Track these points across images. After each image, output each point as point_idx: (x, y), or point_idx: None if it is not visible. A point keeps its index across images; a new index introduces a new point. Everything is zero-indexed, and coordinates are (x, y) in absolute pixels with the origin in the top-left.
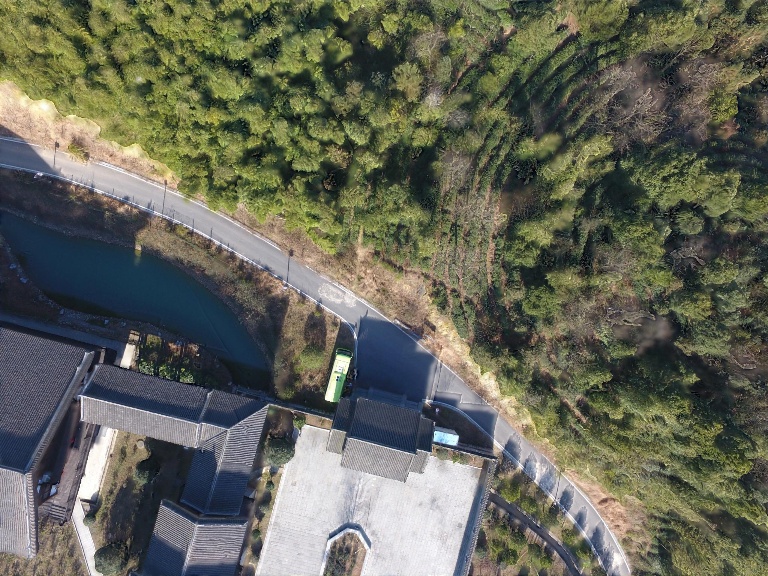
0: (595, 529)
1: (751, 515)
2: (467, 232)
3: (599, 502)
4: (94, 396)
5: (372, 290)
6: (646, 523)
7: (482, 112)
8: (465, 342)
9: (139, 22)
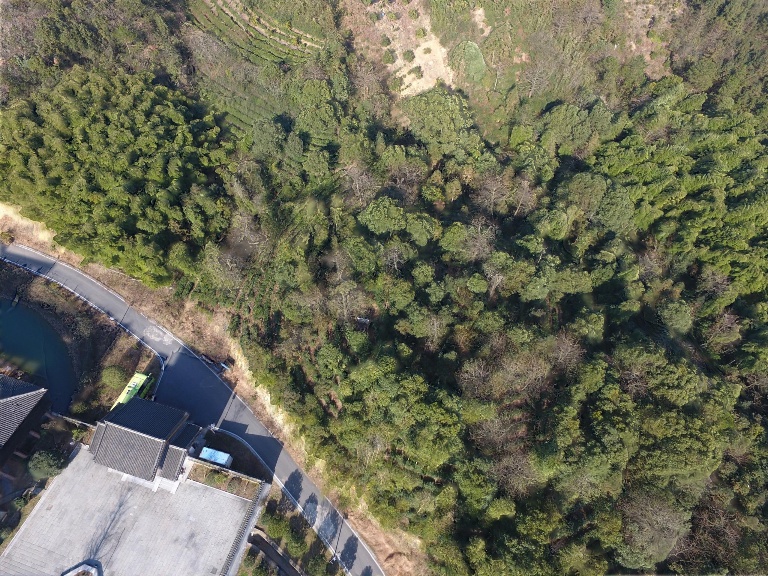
0: None
1: (479, 489)
2: None
3: (385, 559)
4: None
5: (188, 331)
6: (430, 575)
7: (280, 205)
8: None
9: (71, 153)
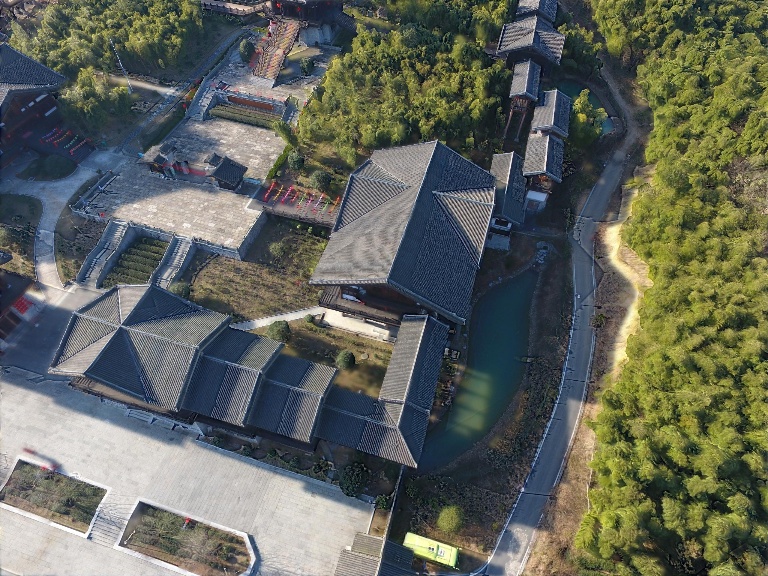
0: None
1: None
2: None
3: None
4: (427, 324)
5: None
6: None
7: None
8: None
9: (744, 364)
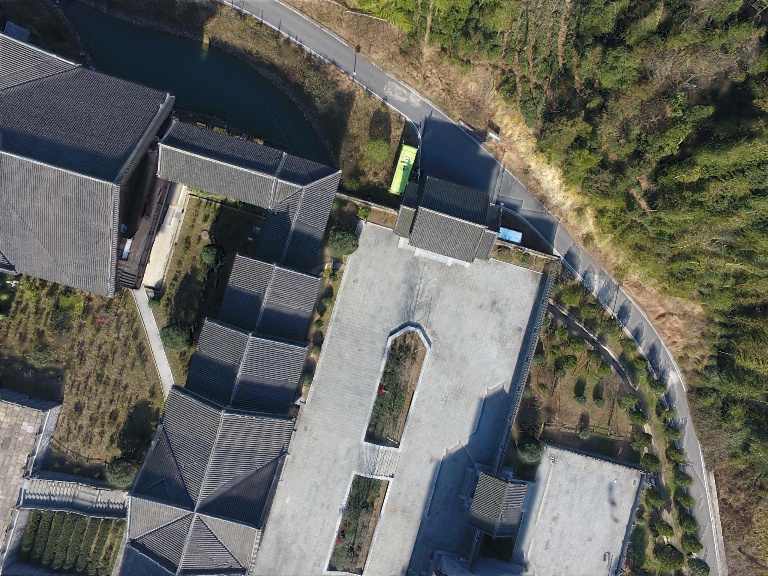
0: (652, 345)
1: None
2: (538, 18)
3: (656, 317)
4: (173, 146)
5: (437, 89)
6: (705, 332)
7: None
8: (532, 134)
9: None
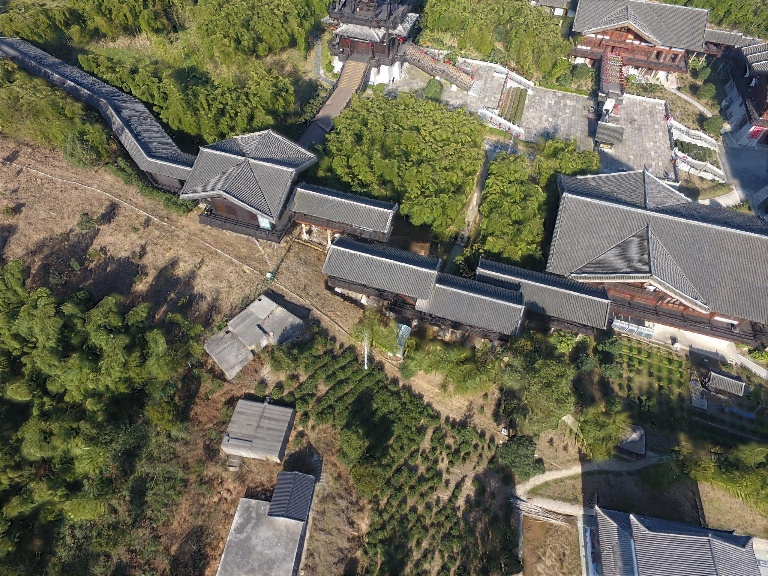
0: None
1: None
2: None
3: None
4: None
5: None
6: None
7: None
8: None
9: None
